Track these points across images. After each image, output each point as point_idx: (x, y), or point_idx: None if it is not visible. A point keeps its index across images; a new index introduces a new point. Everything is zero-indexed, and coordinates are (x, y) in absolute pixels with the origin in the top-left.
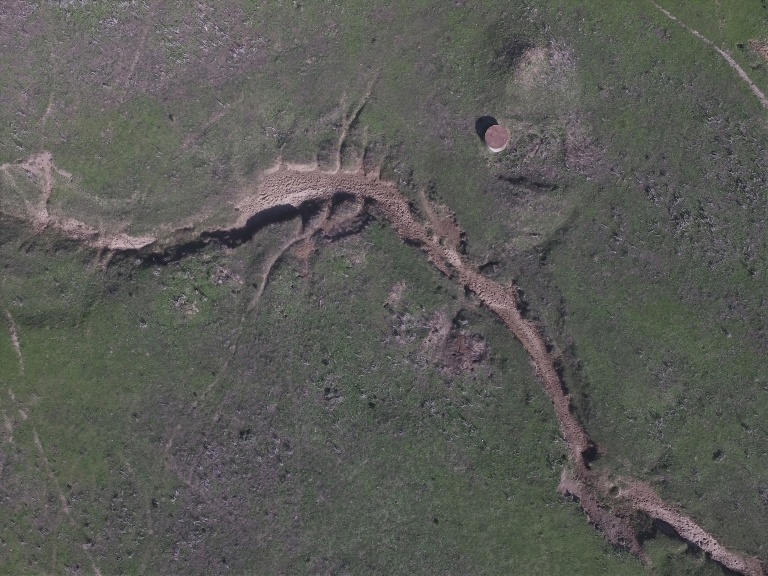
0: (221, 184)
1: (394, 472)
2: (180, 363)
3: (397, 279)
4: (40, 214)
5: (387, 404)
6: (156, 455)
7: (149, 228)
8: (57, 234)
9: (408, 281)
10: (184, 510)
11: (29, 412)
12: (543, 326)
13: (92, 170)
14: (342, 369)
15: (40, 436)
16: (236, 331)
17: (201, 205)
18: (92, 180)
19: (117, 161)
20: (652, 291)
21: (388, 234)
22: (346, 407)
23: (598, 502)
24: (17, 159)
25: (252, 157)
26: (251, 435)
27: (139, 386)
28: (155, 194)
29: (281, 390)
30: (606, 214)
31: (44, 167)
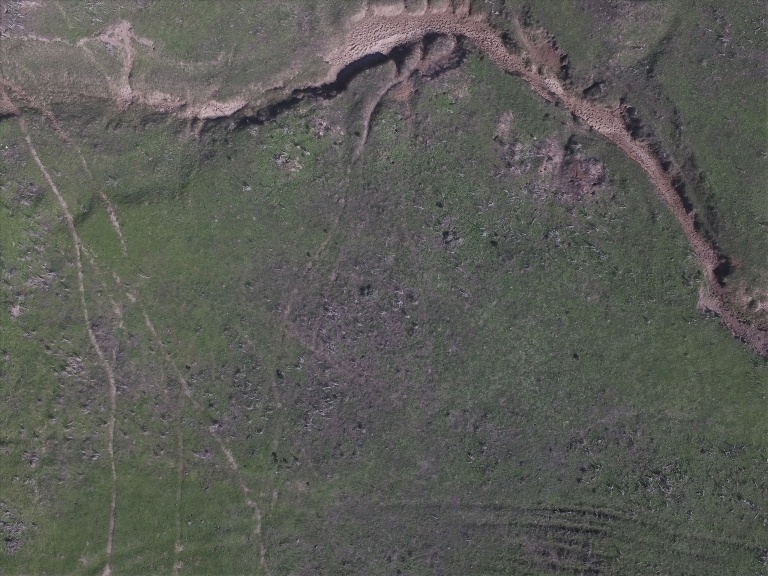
0: (308, 36)
1: (526, 310)
2: (289, 224)
3: (503, 110)
4: (123, 91)
5: (509, 240)
6: (275, 324)
7: (239, 91)
8: (143, 109)
9: (515, 111)
10: (311, 378)
11: (137, 294)
12: (659, 142)
13: (174, 35)
14: (458, 210)
15: (151, 318)
16: (343, 184)
17: (290, 60)
18: (175, 46)
19: (199, 23)
20: (767, 89)
21: (488, 66)
22: (467, 249)
23: (739, 318)
24: (95, 32)
25: (337, 5)
26: (372, 289)
27: (249, 253)
28: (242, 53)
29: (397, 240)
30: (709, 18)
31: (123, 38)
